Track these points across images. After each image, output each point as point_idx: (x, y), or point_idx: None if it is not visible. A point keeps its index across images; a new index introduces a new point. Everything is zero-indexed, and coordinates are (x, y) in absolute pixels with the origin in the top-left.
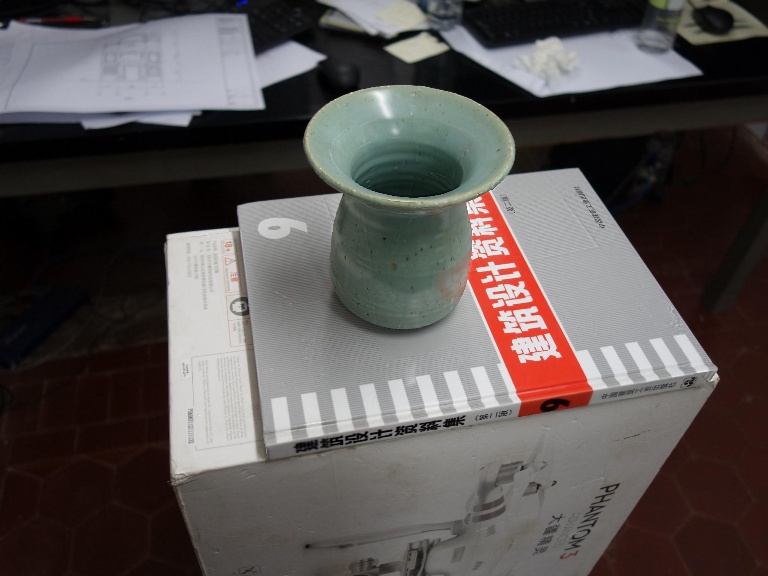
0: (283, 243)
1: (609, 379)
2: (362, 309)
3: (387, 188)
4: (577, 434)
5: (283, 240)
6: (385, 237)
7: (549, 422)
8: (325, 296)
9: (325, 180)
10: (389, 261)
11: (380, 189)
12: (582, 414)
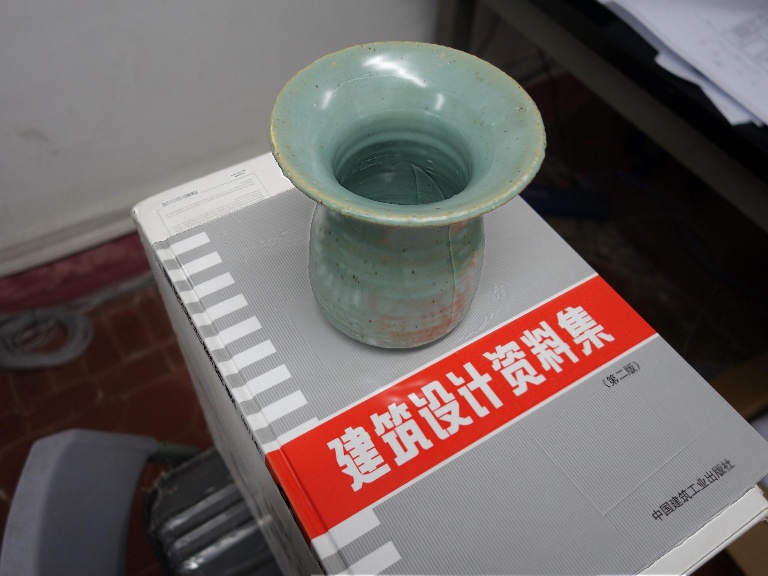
0: None
1: (341, 562)
2: None
3: (454, 191)
4: None
5: None
6: None
7: None
8: None
9: None
10: None
11: (448, 185)
12: None
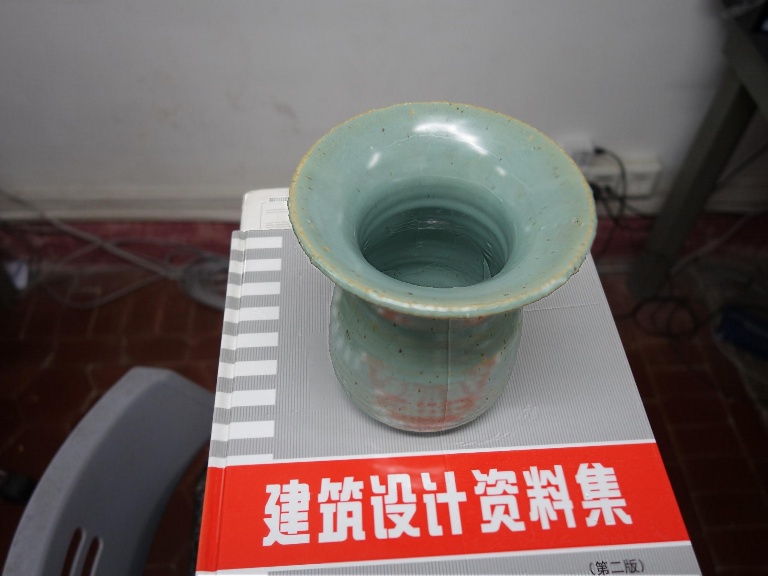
0: None
1: None
2: None
3: None
4: None
5: None
6: None
7: None
8: None
9: None
10: None
11: None
12: None
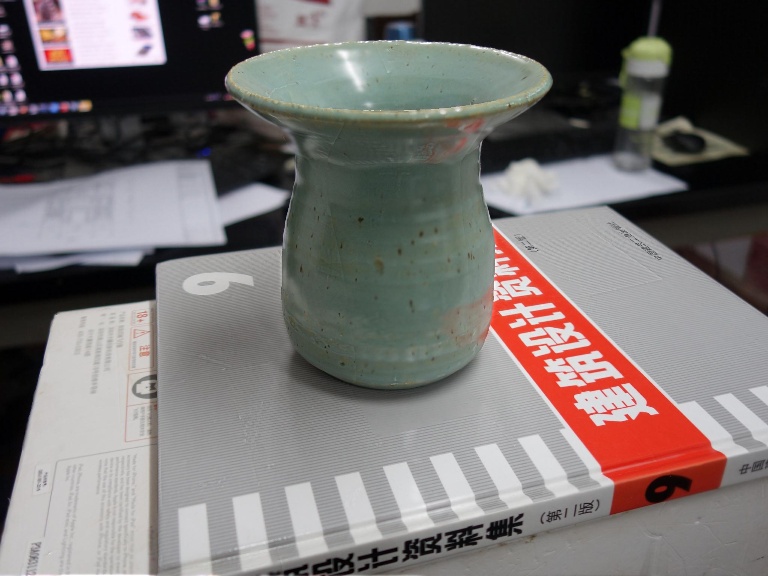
0: (217, 299)
1: (745, 440)
2: (333, 355)
3: None
4: (702, 548)
5: (218, 295)
6: (361, 217)
7: (658, 525)
8: (277, 357)
9: (255, 105)
10: (370, 258)
11: None
12: (708, 508)
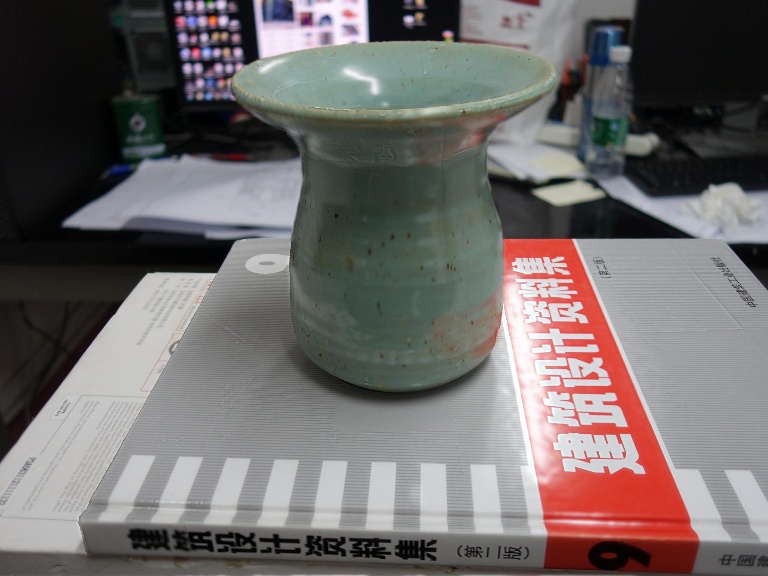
0: (268, 279)
1: (737, 527)
2: (313, 345)
3: None
4: None
5: (270, 276)
6: (337, 213)
7: None
8: (289, 340)
9: (235, 96)
10: (343, 255)
11: None
12: None
